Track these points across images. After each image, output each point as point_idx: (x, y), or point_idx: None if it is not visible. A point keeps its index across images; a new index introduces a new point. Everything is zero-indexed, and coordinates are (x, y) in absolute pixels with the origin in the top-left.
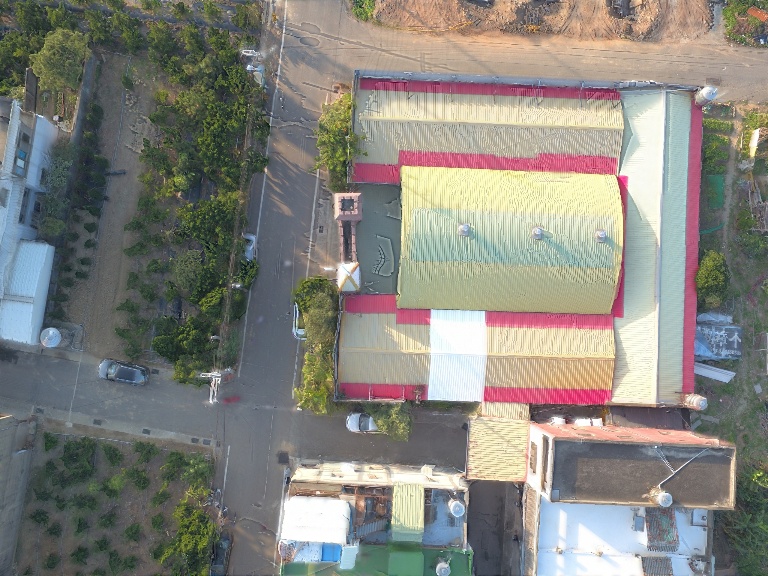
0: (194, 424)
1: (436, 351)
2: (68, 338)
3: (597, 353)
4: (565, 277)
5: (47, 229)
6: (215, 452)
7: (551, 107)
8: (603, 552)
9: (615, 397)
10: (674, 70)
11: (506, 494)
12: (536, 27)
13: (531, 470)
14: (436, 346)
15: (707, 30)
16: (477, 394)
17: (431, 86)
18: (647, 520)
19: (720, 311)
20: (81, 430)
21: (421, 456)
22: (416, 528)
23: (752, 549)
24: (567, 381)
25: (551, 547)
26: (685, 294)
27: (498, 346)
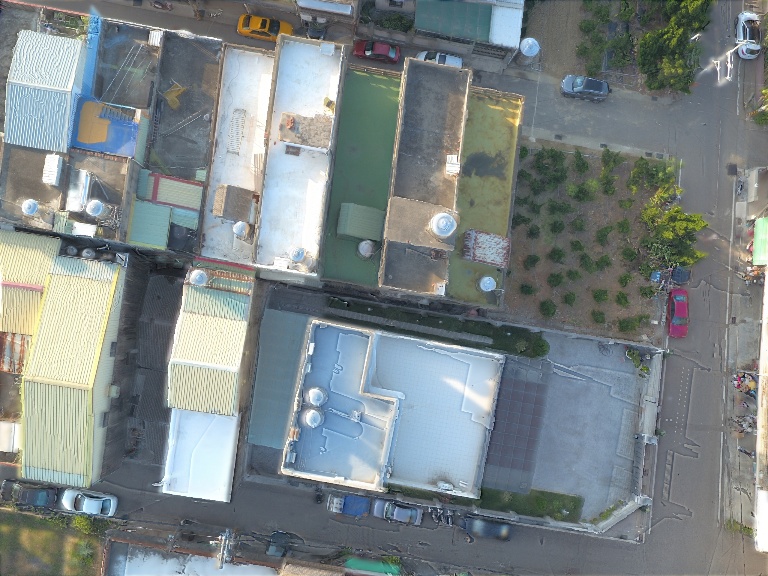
0: (647, 139)
1: None
2: None
3: None
4: None
5: None
6: (668, 165)
7: None
8: None
9: None
10: None
11: None
12: None
13: None
14: None
15: None
16: None
17: None
18: None
19: None
20: None
21: None
22: None
23: None
24: None
25: None
26: None
27: None
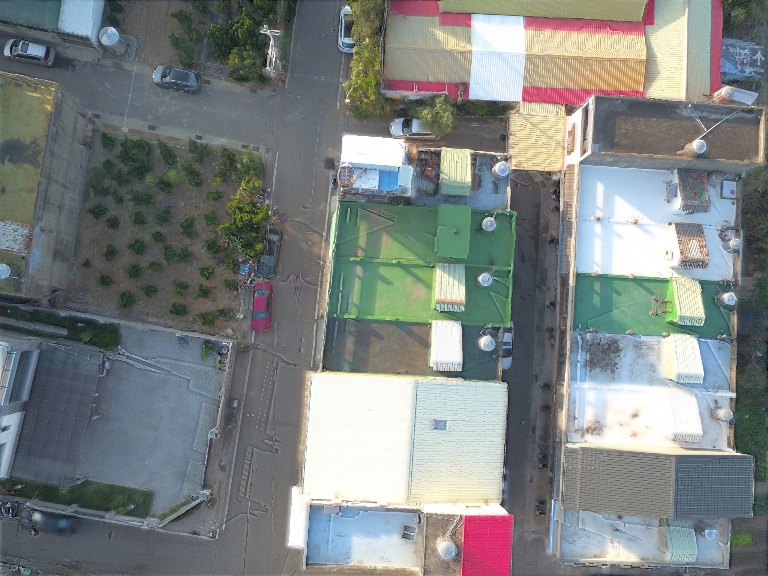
0: (244, 131)
1: (477, 49)
2: (123, 46)
3: (630, 50)
4: None
5: None
6: (264, 158)
7: None
8: (638, 221)
9: None
10: None
11: (541, 201)
12: None
13: (568, 157)
14: (477, 45)
15: None
16: (515, 94)
17: None
18: (680, 184)
19: (744, 31)
20: (136, 135)
21: None
22: (464, 182)
23: None
24: (601, 82)
25: (589, 216)
26: (712, 5)
27: (536, 47)
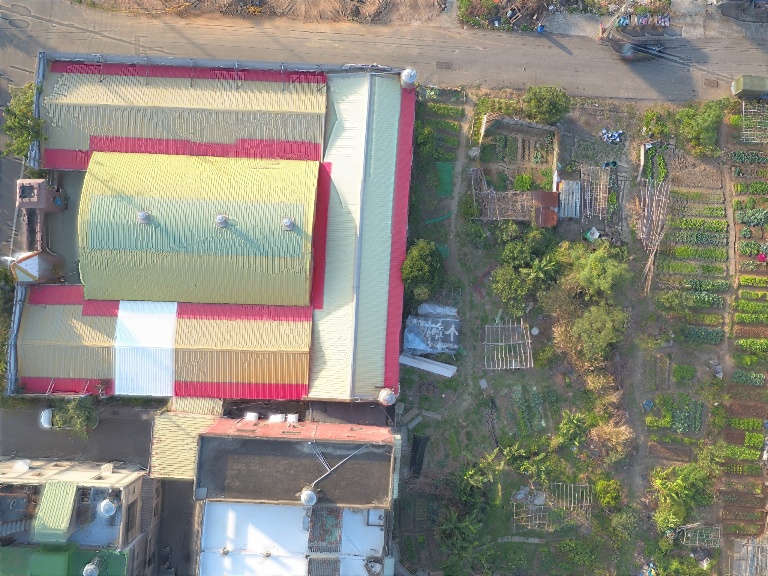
0: None
1: (120, 344)
2: None
3: (286, 346)
4: (249, 267)
5: None
6: None
7: (251, 90)
8: (272, 553)
9: (312, 392)
10: (402, 53)
11: None
12: (257, 9)
13: None
14: (122, 338)
15: (439, 12)
16: (167, 388)
17: (126, 69)
18: (311, 519)
19: (437, 303)
20: None
21: (119, 453)
22: (59, 527)
23: (457, 550)
24: (261, 375)
25: (218, 547)
26: (389, 285)
27: (187, 338)
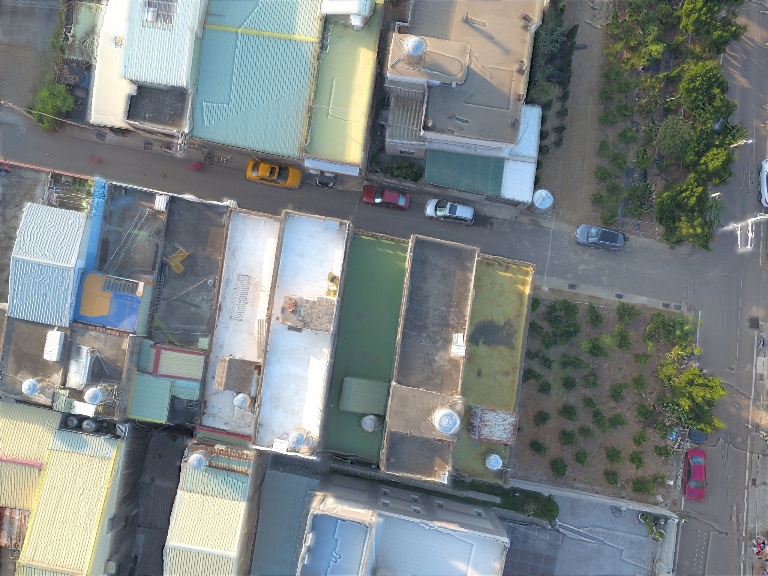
0: (665, 290)
1: None
2: None
3: None
4: None
5: (541, 93)
6: (686, 317)
7: None
8: None
9: None
10: None
11: None
12: None
13: None
14: None
15: None
16: None
17: None
18: None
19: None
20: (556, 294)
21: None
22: None
23: None
24: None
25: None
26: None
27: None
